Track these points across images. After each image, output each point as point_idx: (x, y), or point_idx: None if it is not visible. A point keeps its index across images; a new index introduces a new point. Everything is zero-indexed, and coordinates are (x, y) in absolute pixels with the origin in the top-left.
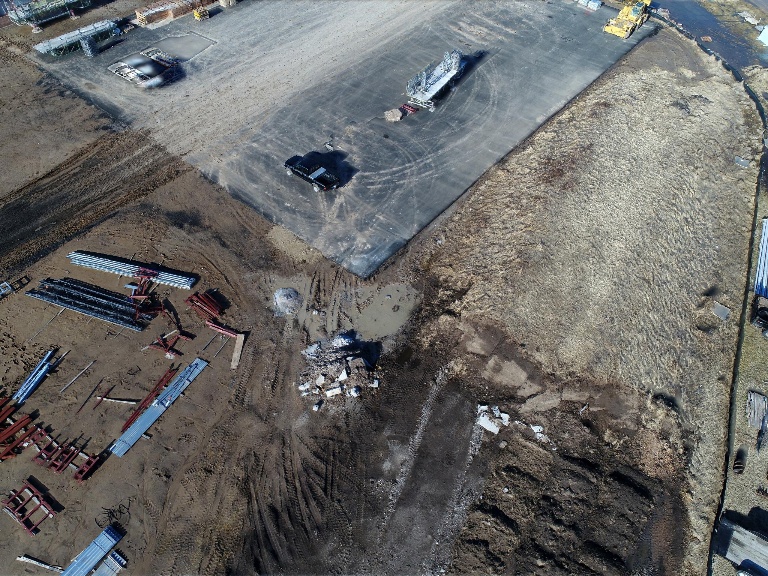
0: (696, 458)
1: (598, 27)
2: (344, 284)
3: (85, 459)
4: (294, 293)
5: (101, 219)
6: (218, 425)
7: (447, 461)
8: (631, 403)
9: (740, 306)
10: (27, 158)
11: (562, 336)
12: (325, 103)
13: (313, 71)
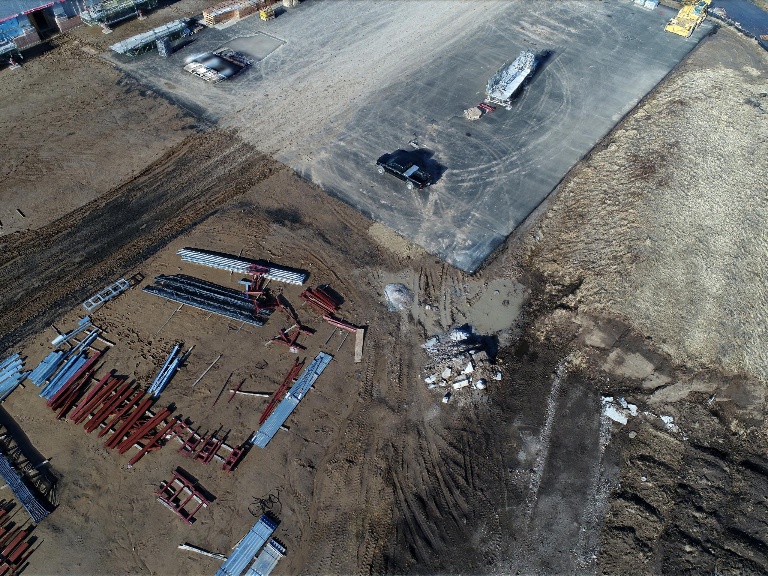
0: None
1: (658, 26)
2: (451, 279)
3: (228, 450)
4: (404, 288)
5: (203, 217)
6: (352, 417)
7: (580, 451)
8: (758, 394)
9: None
10: (120, 157)
11: (686, 329)
12: (403, 102)
13: (386, 70)
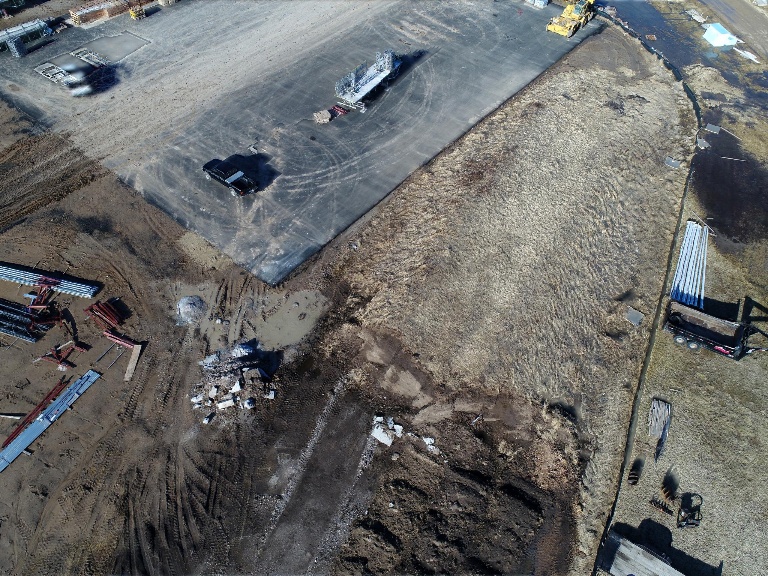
0: (590, 469)
1: (543, 25)
2: (252, 291)
3: None
4: (199, 301)
5: (8, 226)
6: (104, 440)
7: (336, 475)
8: (525, 413)
9: (654, 311)
10: None
11: (458, 345)
12: (254, 104)
13: (246, 71)
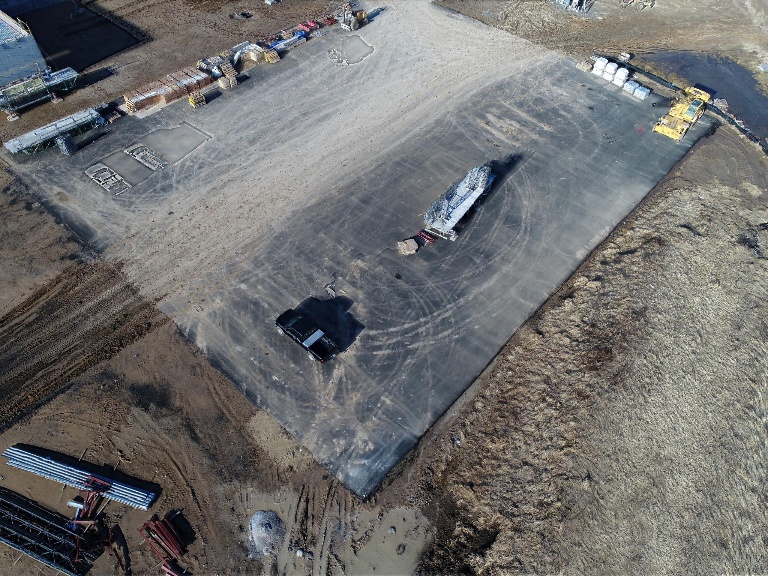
0: None
1: (646, 123)
2: (338, 507)
3: None
4: (275, 520)
5: (52, 394)
6: None
7: None
8: None
9: None
10: None
11: None
12: (329, 226)
13: (318, 180)
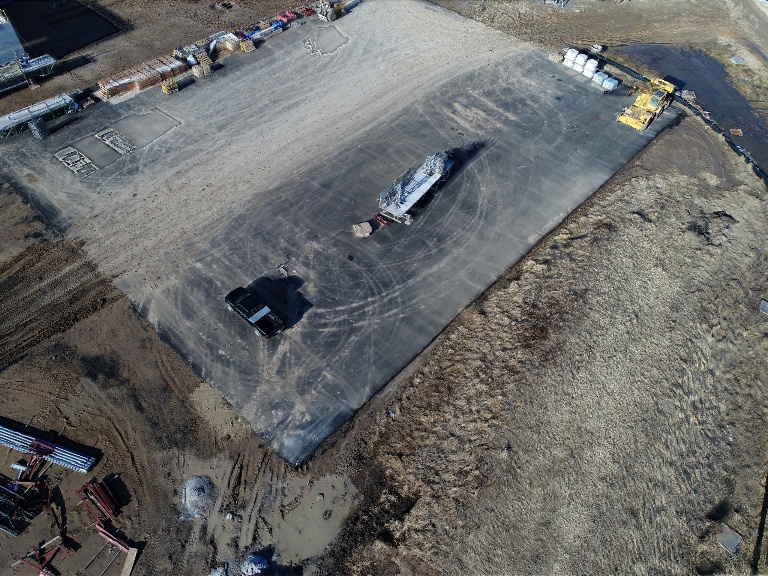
0: None
1: (612, 113)
2: (270, 474)
3: None
4: (208, 485)
5: (5, 364)
6: None
7: None
8: None
9: (755, 533)
10: None
11: None
12: (288, 209)
13: (281, 165)
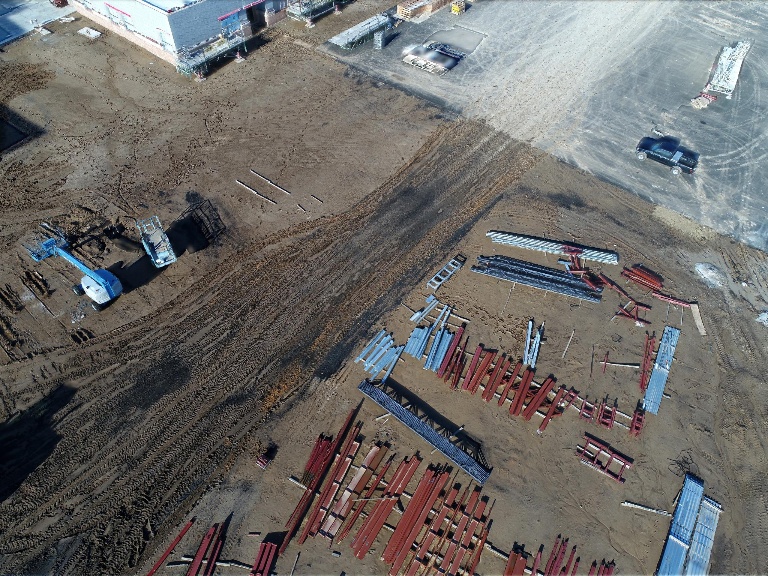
0: None
1: None
2: (754, 258)
3: (624, 417)
4: (714, 267)
5: (492, 201)
6: (723, 385)
7: None
8: None
9: None
10: (384, 145)
11: None
12: (627, 92)
13: (596, 62)
